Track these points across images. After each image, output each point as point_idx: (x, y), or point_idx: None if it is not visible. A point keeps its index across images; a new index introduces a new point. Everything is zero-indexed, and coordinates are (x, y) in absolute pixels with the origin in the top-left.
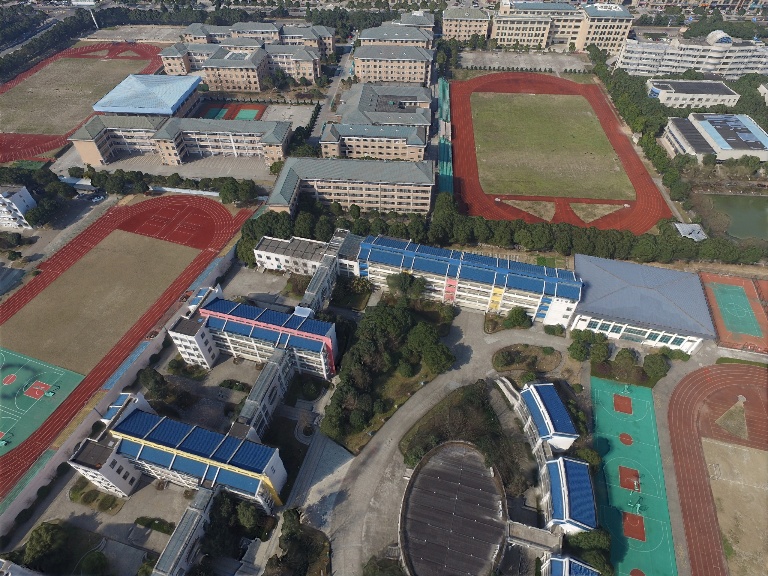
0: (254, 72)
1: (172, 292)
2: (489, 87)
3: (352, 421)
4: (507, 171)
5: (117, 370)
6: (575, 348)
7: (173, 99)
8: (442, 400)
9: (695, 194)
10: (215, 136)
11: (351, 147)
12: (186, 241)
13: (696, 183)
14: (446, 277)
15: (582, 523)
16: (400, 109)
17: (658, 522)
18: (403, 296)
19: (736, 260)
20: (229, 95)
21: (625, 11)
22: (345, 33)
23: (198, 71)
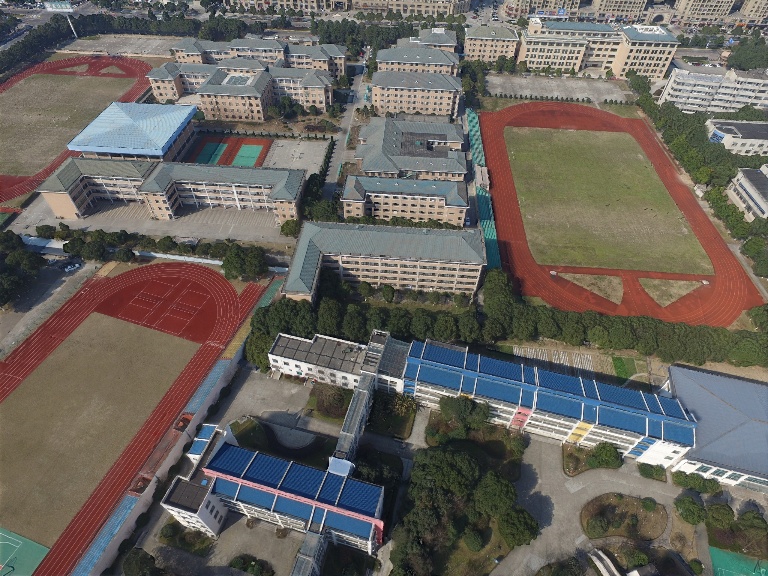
0: (257, 100)
1: (164, 409)
2: (523, 120)
3: None
4: (559, 233)
5: (92, 544)
6: (689, 509)
7: (164, 137)
8: None
9: None
10: (215, 187)
11: (378, 204)
12: (181, 331)
13: None
14: (518, 405)
15: None
16: (429, 151)
17: None
18: (462, 427)
19: None
20: (228, 126)
21: (669, 35)
22: (356, 50)
23: (192, 95)
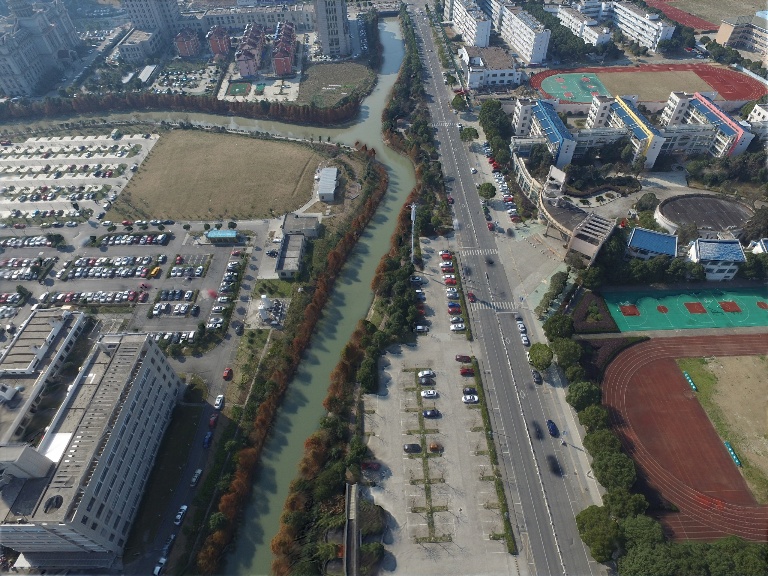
0: None
1: None
2: None
3: (706, 175)
4: None
5: None
6: None
7: None
8: None
9: None
10: None
11: None
12: (722, 92)
13: None
14: None
15: (766, 249)
16: None
17: None
18: None
19: None
20: None
21: None
22: None
23: None
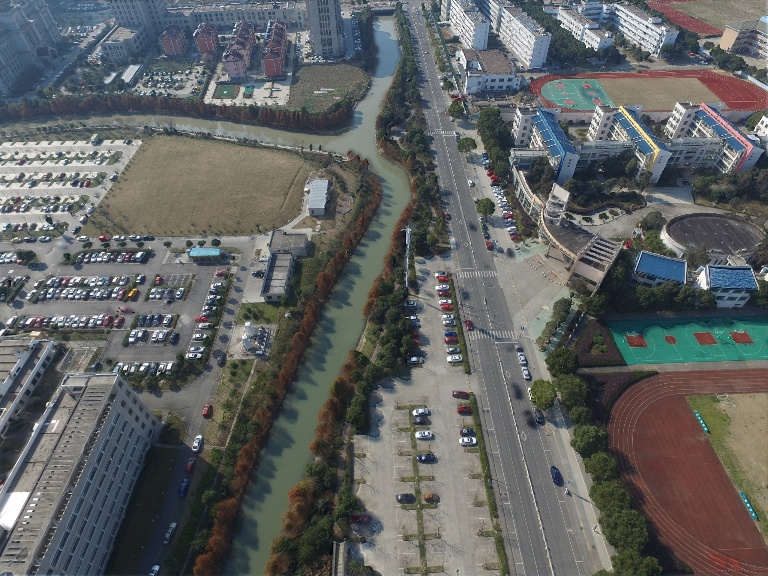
0: None
1: None
2: None
3: (713, 192)
4: None
5: None
6: None
7: None
8: None
9: None
10: None
11: None
12: (727, 101)
13: None
14: None
15: None
16: None
17: None
18: None
19: None
20: None
21: None
22: None
23: None
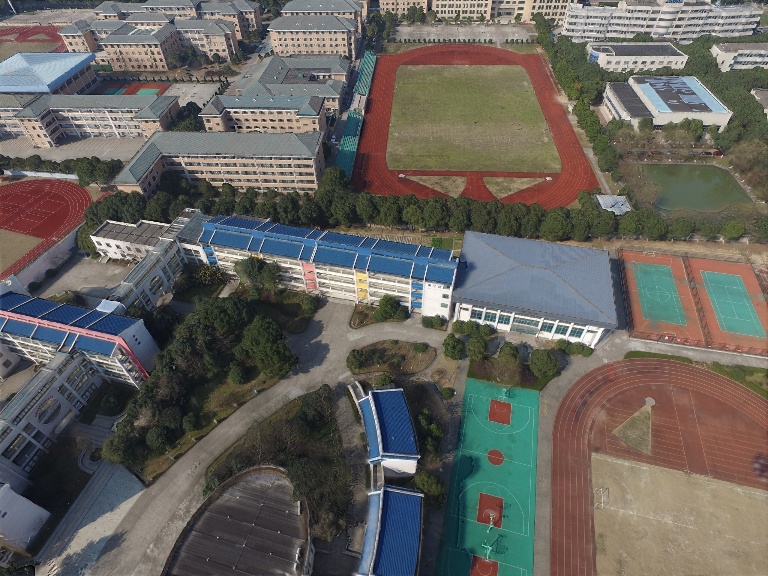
0: (158, 48)
1: None
2: (420, 59)
3: (148, 442)
4: (420, 145)
5: None
6: (448, 343)
7: (53, 76)
8: (276, 412)
9: (625, 162)
10: (90, 114)
11: (239, 121)
12: (29, 230)
13: (627, 150)
14: (300, 261)
15: None
16: (309, 82)
17: (517, 569)
18: (252, 285)
19: (664, 235)
20: (133, 75)
21: None
22: (276, 10)
23: (104, 51)
